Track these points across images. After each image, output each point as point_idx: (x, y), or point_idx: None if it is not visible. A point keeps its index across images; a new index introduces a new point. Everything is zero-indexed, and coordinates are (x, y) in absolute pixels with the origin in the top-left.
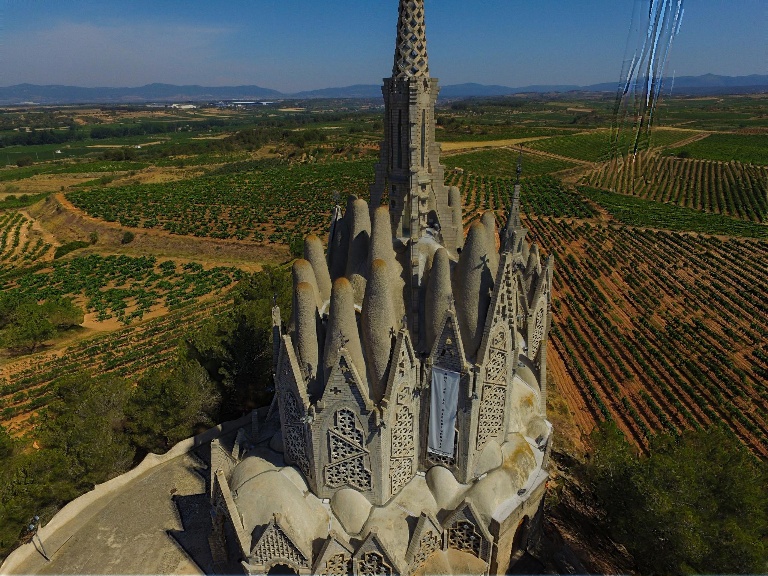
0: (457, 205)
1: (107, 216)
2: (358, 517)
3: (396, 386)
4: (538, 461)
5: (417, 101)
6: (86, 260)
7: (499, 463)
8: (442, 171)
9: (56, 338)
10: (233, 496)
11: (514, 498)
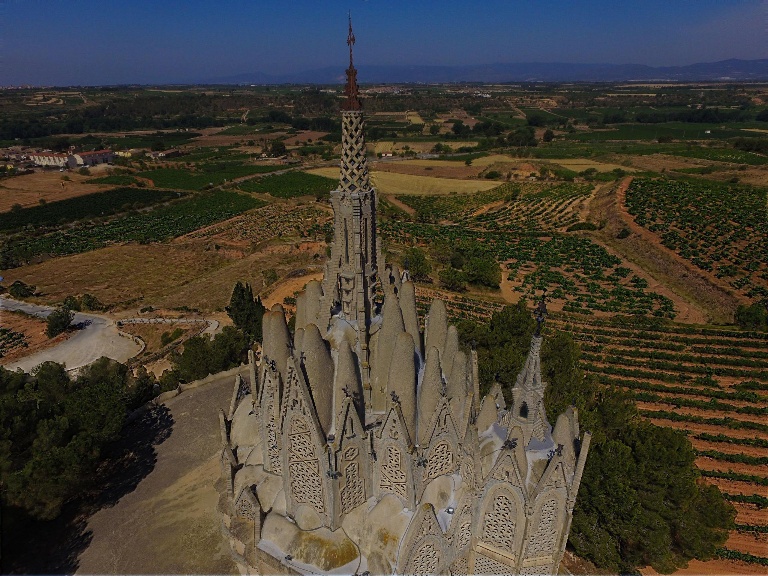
0: (386, 311)
1: (633, 208)
2: (251, 458)
3: (267, 399)
4: (334, 573)
5: (339, 211)
6: (575, 241)
7: (302, 526)
8: (356, 274)
9: (476, 288)
10: (244, 394)
11: (282, 553)
